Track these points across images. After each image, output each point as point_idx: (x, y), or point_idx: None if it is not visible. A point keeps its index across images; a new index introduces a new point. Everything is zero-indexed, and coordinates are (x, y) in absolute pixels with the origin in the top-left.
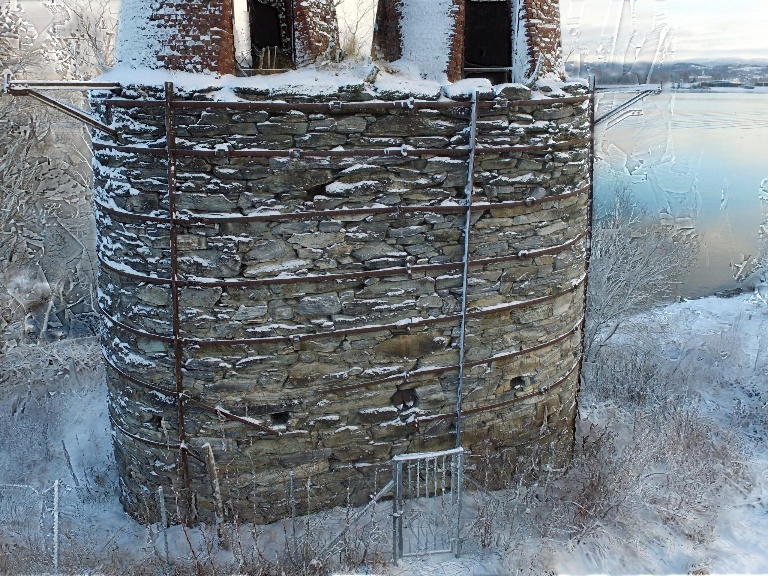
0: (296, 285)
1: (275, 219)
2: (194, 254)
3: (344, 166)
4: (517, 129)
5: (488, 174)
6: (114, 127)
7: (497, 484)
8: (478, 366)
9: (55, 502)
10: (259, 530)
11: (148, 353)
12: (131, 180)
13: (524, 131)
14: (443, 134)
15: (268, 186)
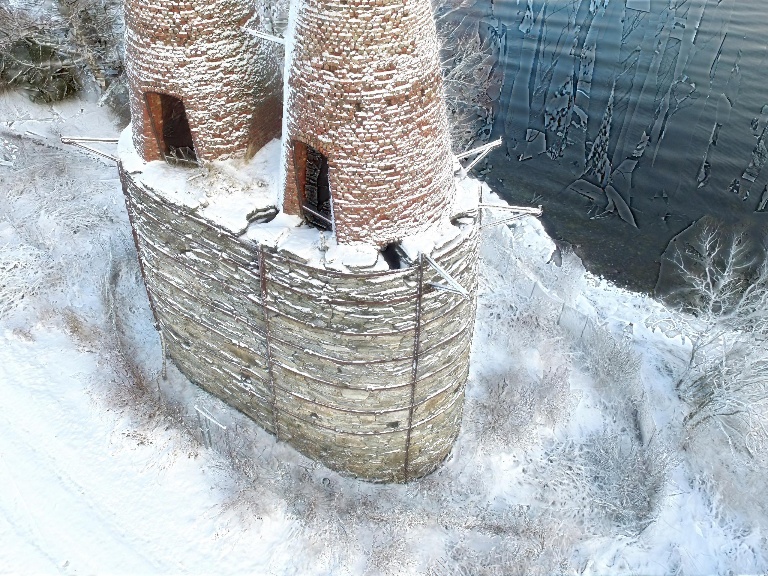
0: None
1: None
2: None
3: None
4: (295, 278)
5: (277, 294)
6: None
7: (307, 454)
8: None
9: None
10: (183, 382)
11: None
12: None
13: (302, 281)
14: None
15: None
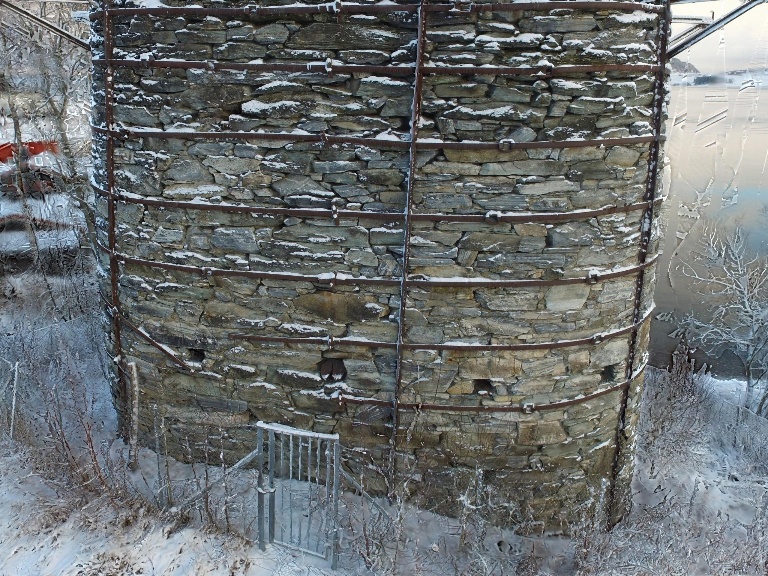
0: (210, 213)
1: (190, 137)
2: (127, 168)
3: (262, 82)
4: (487, 43)
5: (442, 102)
6: (89, 41)
7: (451, 509)
8: (423, 351)
9: (15, 381)
10: (172, 465)
11: (104, 264)
12: (93, 92)
13: (499, 46)
14: (384, 48)
15: (187, 101)
